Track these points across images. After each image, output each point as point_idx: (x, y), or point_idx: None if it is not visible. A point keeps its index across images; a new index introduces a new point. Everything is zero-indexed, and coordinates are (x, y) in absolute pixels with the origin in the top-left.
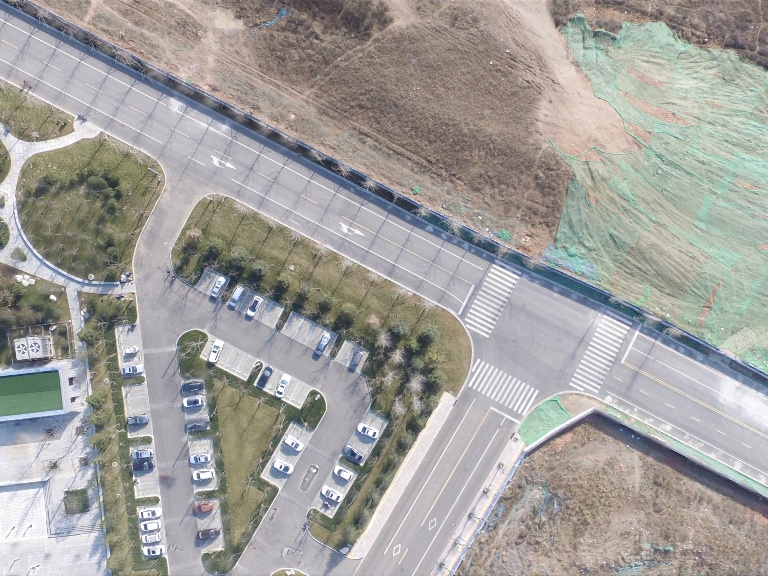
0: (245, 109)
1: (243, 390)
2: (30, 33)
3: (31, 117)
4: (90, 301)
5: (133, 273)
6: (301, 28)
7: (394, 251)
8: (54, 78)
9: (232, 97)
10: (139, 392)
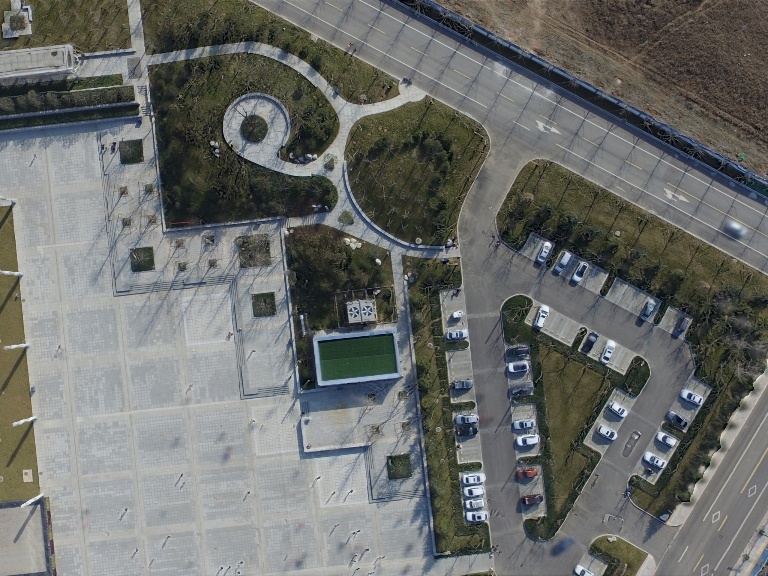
0: (572, 74)
1: (569, 355)
2: None
3: (358, 80)
4: (415, 265)
5: (457, 238)
6: None
7: (718, 218)
8: (378, 41)
9: (558, 62)
10: (462, 357)
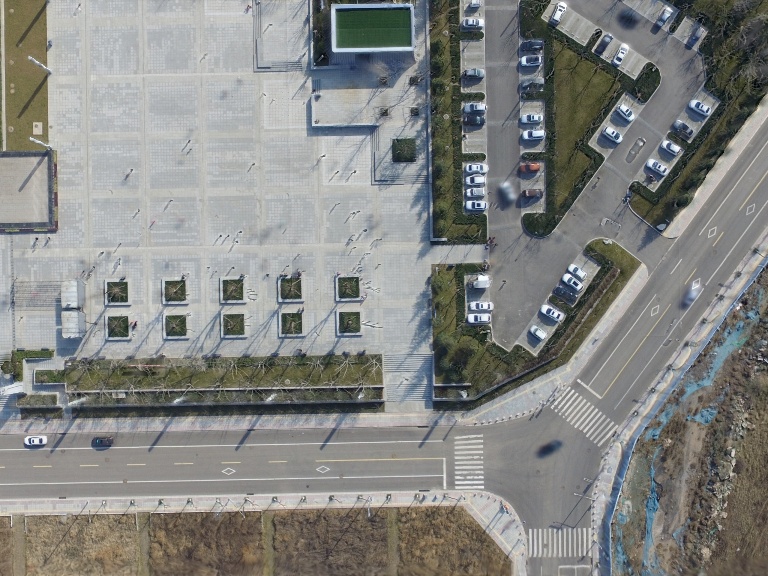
0: None
1: (582, 54)
2: None
3: None
4: None
5: None
6: None
7: None
8: None
9: None
10: (476, 48)
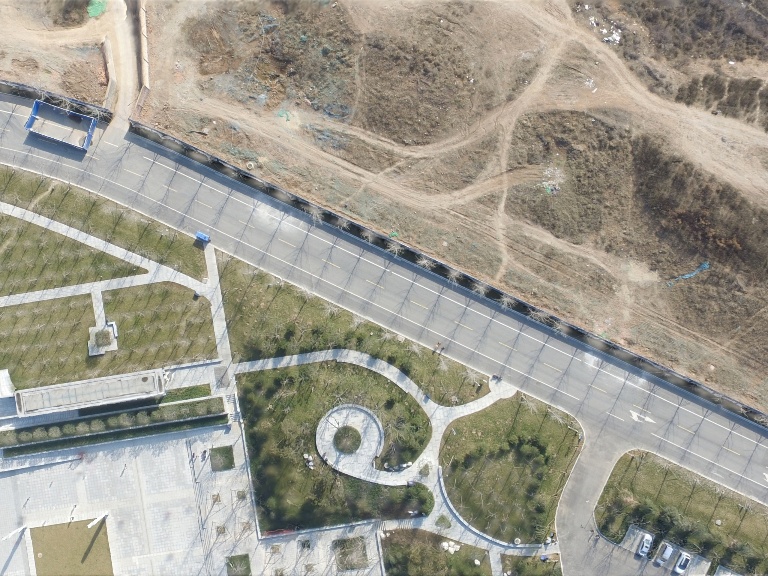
0: (665, 363)
1: None
2: (439, 293)
3: (449, 381)
4: (514, 564)
5: (556, 533)
6: (724, 281)
7: None
8: (466, 338)
9: (649, 350)
10: None
